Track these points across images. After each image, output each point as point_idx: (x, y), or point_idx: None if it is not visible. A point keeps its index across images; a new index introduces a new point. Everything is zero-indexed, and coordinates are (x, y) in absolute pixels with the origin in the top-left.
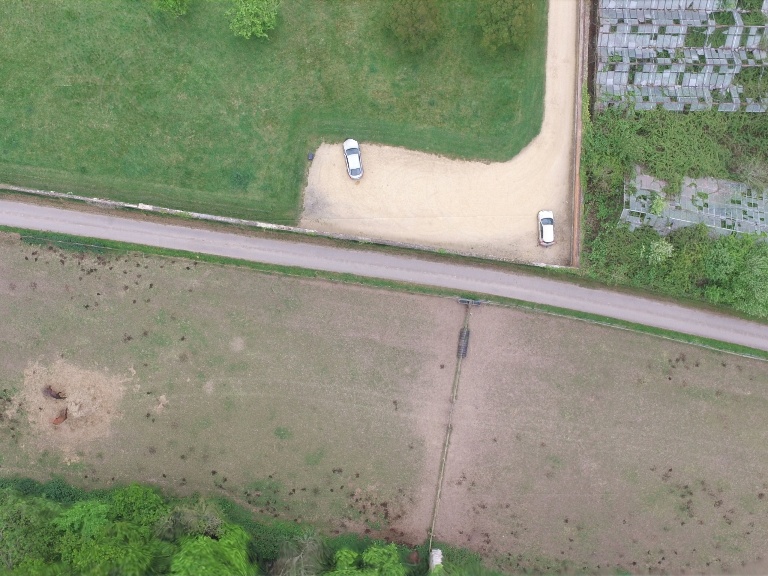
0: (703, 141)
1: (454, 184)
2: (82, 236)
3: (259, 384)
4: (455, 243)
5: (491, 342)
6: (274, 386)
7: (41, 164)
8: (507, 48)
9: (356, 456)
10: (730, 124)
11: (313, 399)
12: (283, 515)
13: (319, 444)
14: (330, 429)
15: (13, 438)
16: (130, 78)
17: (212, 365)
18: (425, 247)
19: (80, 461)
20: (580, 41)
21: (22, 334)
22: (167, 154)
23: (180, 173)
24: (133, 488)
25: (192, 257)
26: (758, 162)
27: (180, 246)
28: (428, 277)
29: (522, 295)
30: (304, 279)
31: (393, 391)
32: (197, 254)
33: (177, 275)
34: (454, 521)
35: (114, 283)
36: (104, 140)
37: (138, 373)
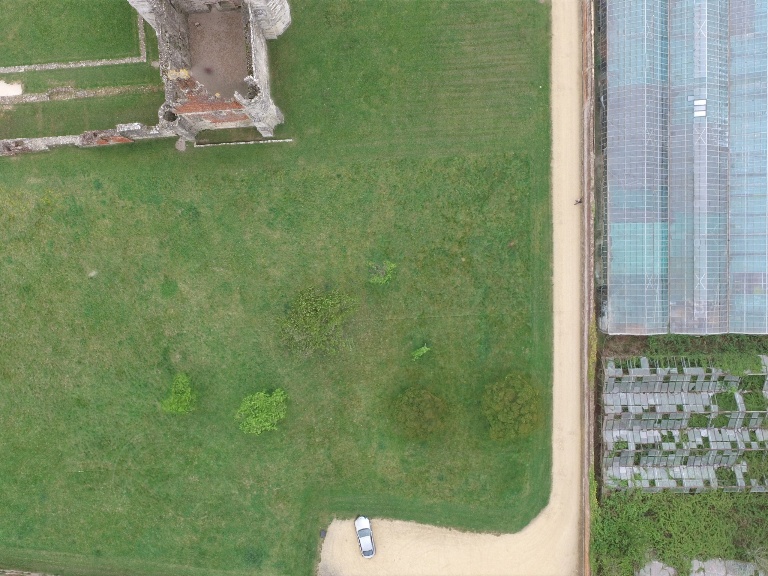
0: (709, 520)
1: (465, 556)
2: None
3: None
4: None
5: None
6: None
7: (56, 549)
8: None
9: None
10: (735, 501)
11: None
12: None
13: None
14: None
15: None
16: (141, 462)
17: None
18: None
19: None
20: (585, 418)
21: None
22: (181, 535)
23: (194, 553)
24: None
25: None
26: (764, 533)
27: None
28: None
29: None
30: None
31: None
32: None
33: None
34: None
35: None
36: (118, 523)
37: None
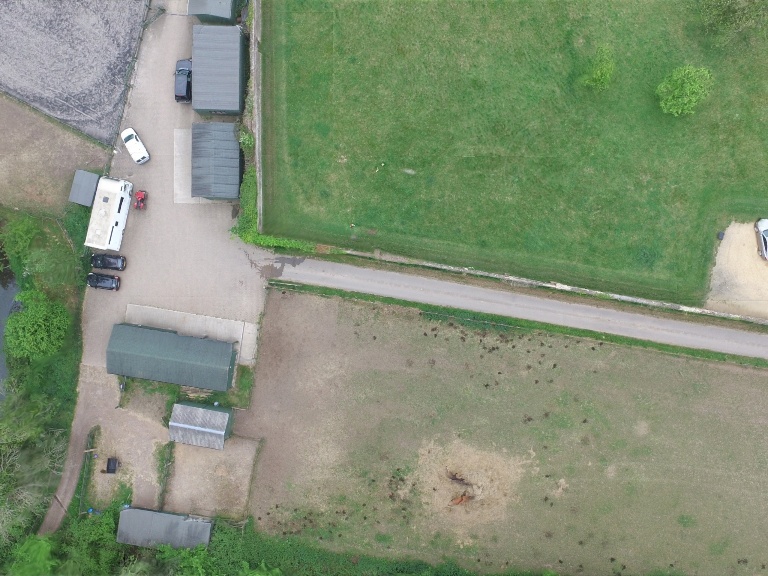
0: None
1: None
2: (483, 313)
3: (662, 470)
4: None
5: None
6: (678, 472)
7: (439, 236)
8: None
9: (762, 547)
10: None
11: (718, 487)
12: None
13: (724, 533)
14: (736, 518)
15: (404, 519)
16: (536, 150)
17: (614, 449)
18: None
19: (473, 544)
20: None
21: (417, 412)
22: (571, 229)
23: (583, 249)
24: None
25: (598, 337)
26: None
27: (584, 325)
28: None
29: None
30: (713, 363)
31: None
32: (603, 334)
33: (582, 355)
34: None
35: (516, 362)
36: (506, 213)
37: (537, 455)
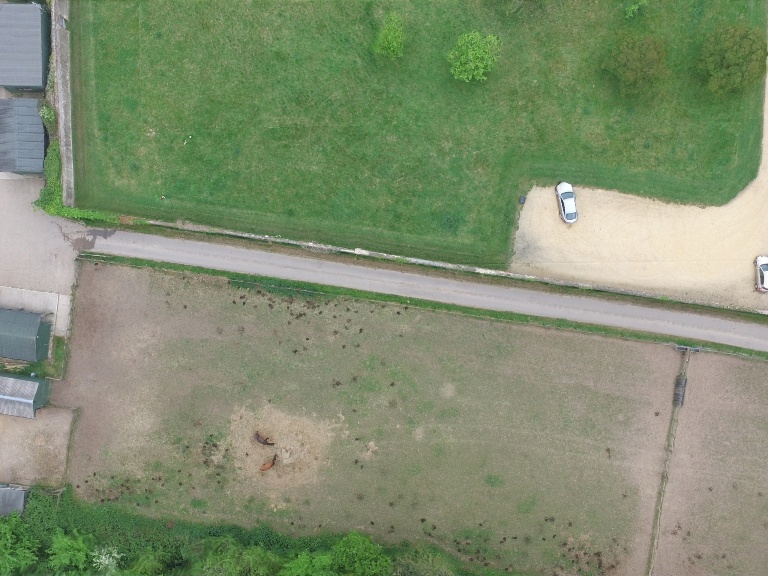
0: None
1: (668, 228)
2: (291, 280)
3: (470, 431)
4: (669, 288)
5: (707, 389)
6: (485, 433)
7: (248, 206)
8: None
9: (569, 504)
10: None
11: (525, 446)
12: (493, 564)
13: (531, 492)
14: (542, 477)
15: (218, 484)
16: (339, 120)
17: (422, 411)
18: (647, 294)
19: (286, 508)
20: None
21: (229, 379)
22: (376, 197)
23: (389, 216)
24: (353, 538)
25: (403, 302)
26: None
27: (390, 290)
28: (643, 323)
29: (739, 342)
30: (516, 324)
31: (606, 439)
32: (408, 299)
33: (387, 320)
34: (669, 571)
35: (323, 328)
36: (312, 182)
37: (347, 419)
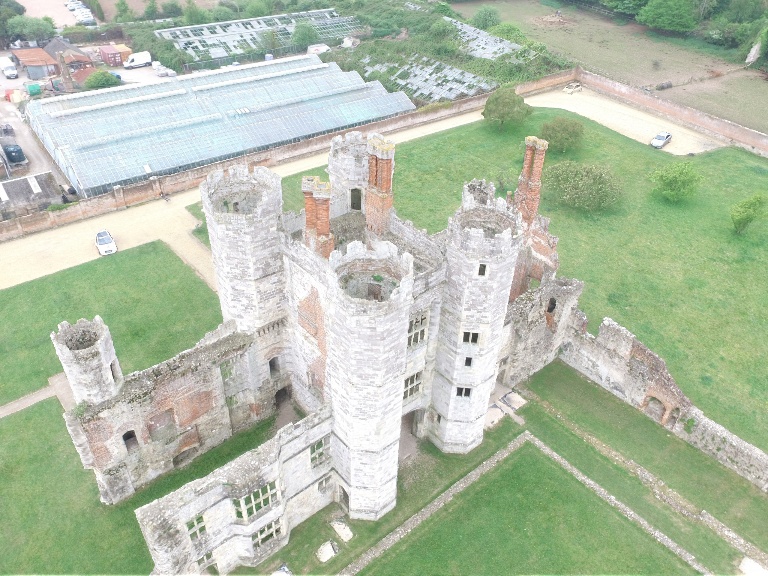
0: None
1: None
2: None
3: None
4: None
5: None
6: None
7: None
8: (511, 125)
9: None
10: None
11: None
12: None
13: None
14: None
15: None
16: None
17: None
18: None
19: None
20: None
21: None
22: None
23: None
24: None
25: None
26: None
27: None
28: None
29: None
30: None
31: None
32: None
33: None
34: None
35: None
36: None
37: None
